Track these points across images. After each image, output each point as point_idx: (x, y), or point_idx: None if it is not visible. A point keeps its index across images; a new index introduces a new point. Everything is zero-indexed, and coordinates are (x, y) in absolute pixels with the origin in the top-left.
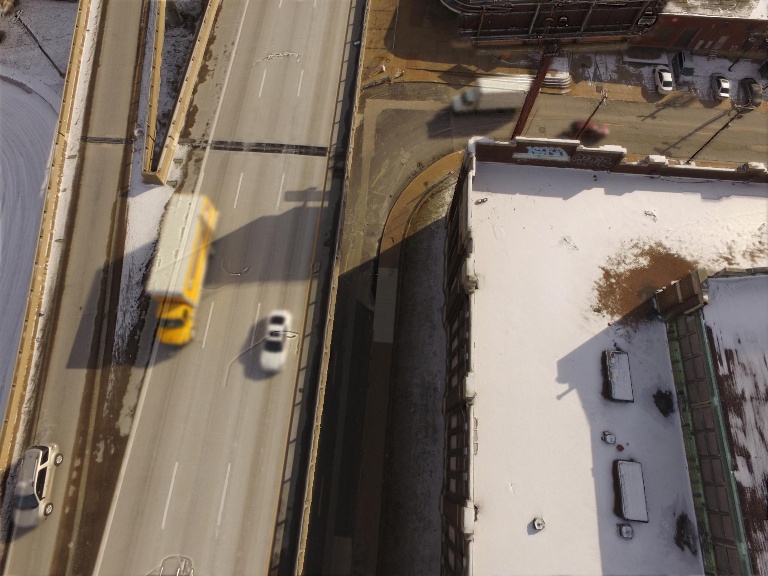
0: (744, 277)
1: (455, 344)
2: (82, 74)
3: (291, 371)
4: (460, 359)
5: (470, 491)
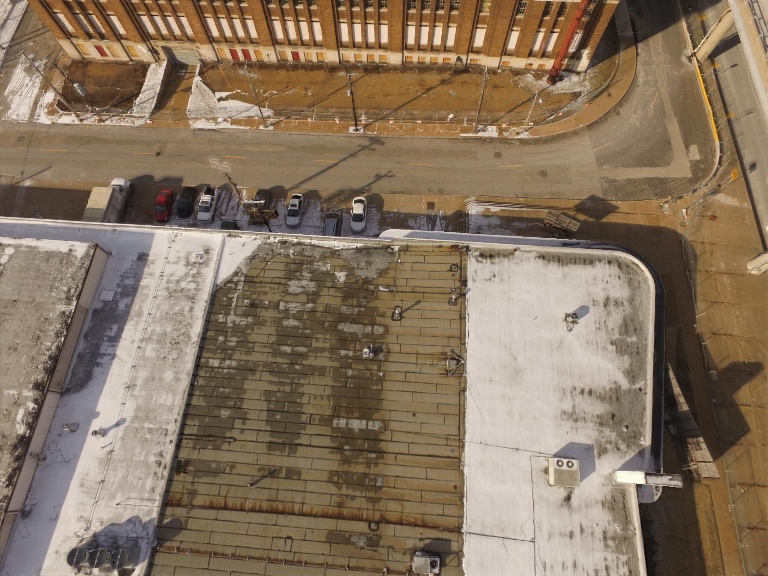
0: None
1: None
2: None
3: None
4: None
5: None
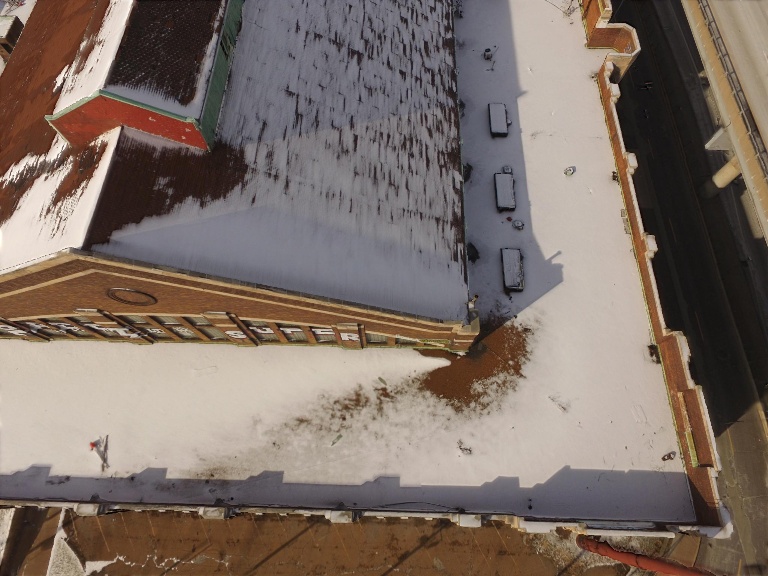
0: None
1: None
2: None
3: None
4: None
5: None
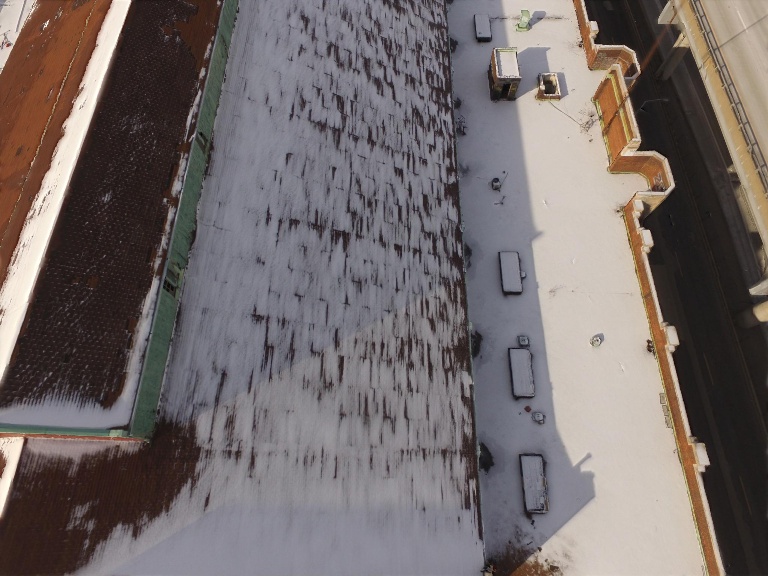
0: None
1: None
2: None
3: None
4: None
5: None
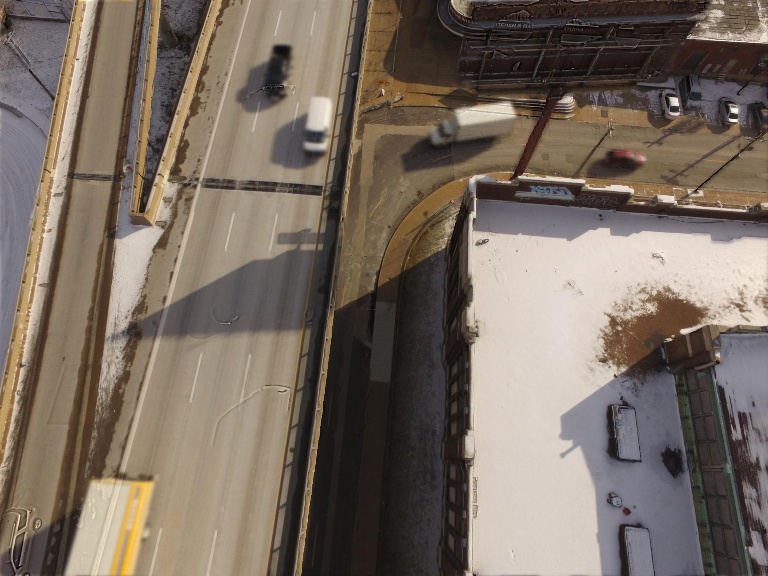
0: (758, 334)
1: (454, 389)
2: (70, 106)
3: (282, 429)
4: (459, 409)
5: (469, 561)
